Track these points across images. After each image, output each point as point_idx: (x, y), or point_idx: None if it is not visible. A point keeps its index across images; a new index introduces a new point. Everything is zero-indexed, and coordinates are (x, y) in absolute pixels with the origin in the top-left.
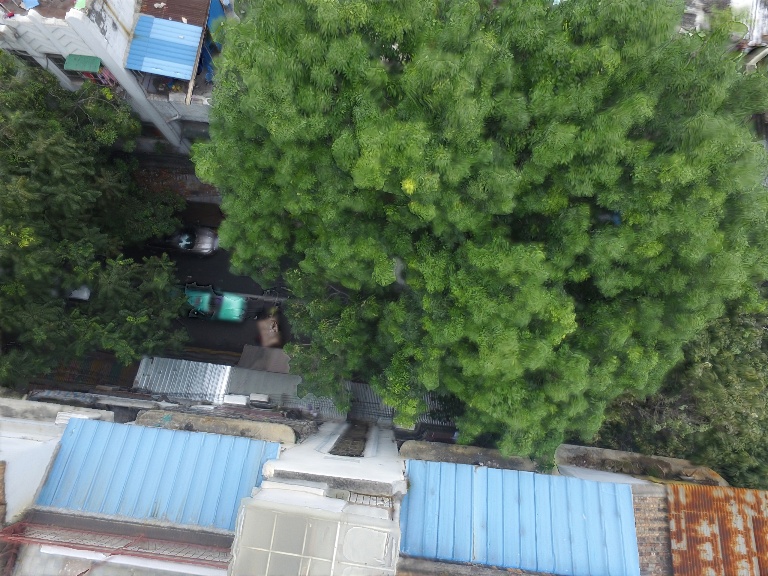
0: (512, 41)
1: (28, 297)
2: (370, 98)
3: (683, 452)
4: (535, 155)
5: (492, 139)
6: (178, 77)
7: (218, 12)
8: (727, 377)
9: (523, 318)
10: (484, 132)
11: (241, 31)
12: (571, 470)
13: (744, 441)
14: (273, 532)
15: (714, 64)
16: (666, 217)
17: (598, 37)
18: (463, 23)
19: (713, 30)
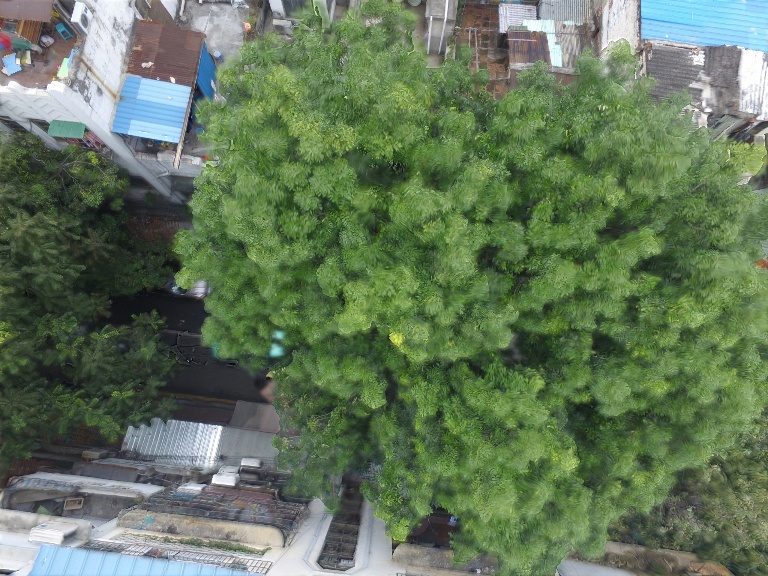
0: (509, 157)
1: (7, 382)
2: (358, 219)
3: (690, 544)
4: (534, 287)
5: (488, 261)
6: (166, 140)
7: (208, 66)
8: (737, 479)
9: (521, 461)
10: (479, 252)
11: (224, 128)
12: (573, 571)
13: (755, 537)
14: None
15: (726, 199)
16: (675, 355)
17: (601, 161)
18: (456, 141)
19: (720, 105)
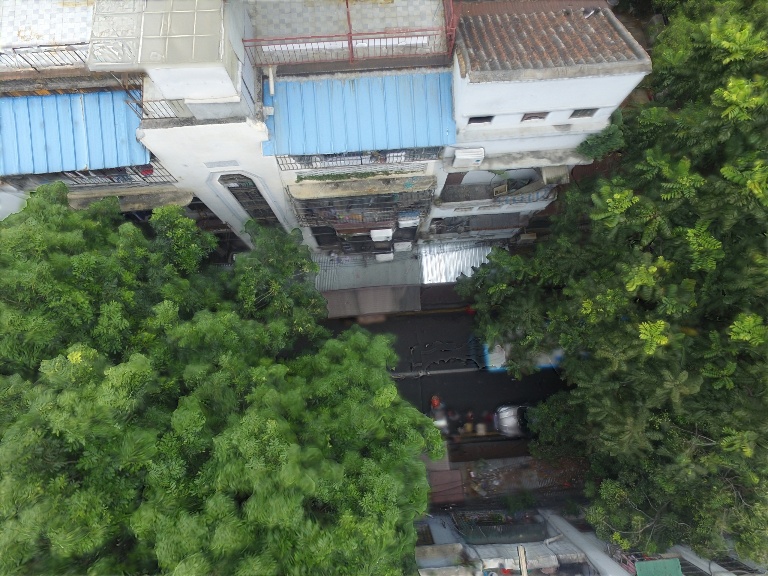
0: None
1: None
2: None
3: None
4: None
5: None
6: None
7: None
8: None
9: None
10: None
11: None
12: None
13: None
14: (194, 48)
15: None
16: None
17: None
18: None
19: None
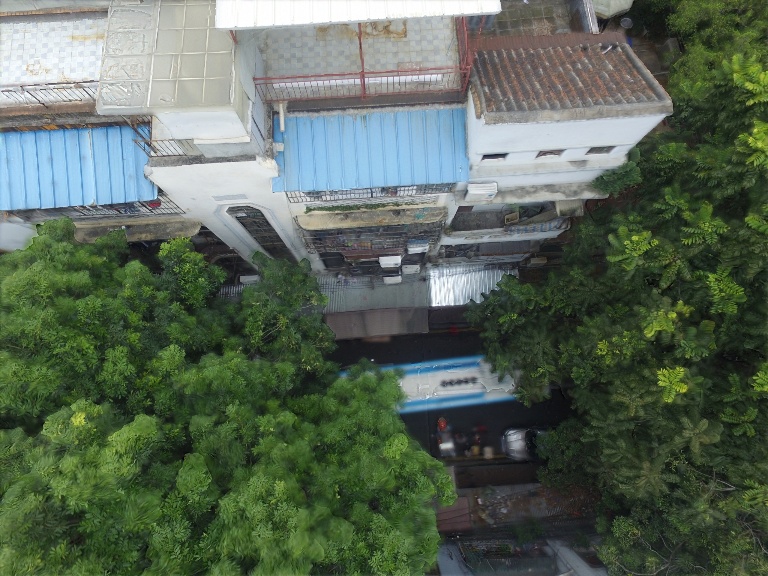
0: None
1: None
2: None
3: None
4: None
5: None
6: None
7: None
8: None
9: None
10: None
11: None
12: None
13: None
14: (204, 91)
15: None
16: None
17: None
18: None
19: None
